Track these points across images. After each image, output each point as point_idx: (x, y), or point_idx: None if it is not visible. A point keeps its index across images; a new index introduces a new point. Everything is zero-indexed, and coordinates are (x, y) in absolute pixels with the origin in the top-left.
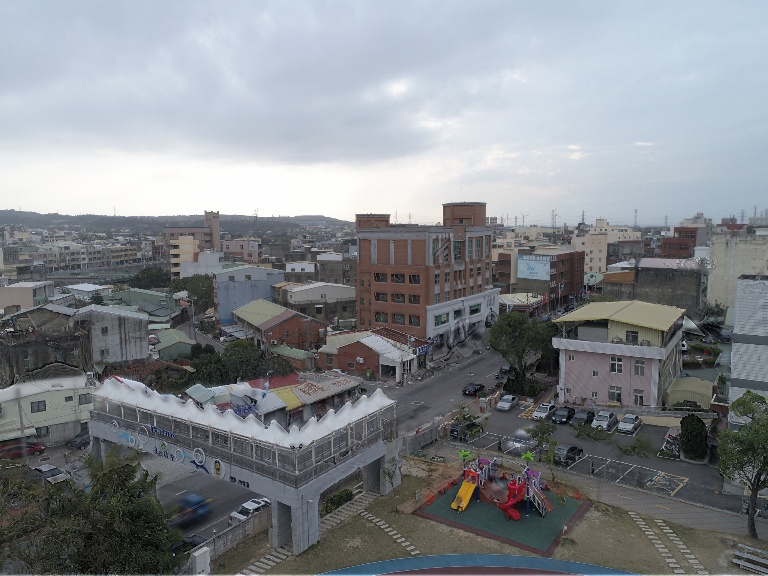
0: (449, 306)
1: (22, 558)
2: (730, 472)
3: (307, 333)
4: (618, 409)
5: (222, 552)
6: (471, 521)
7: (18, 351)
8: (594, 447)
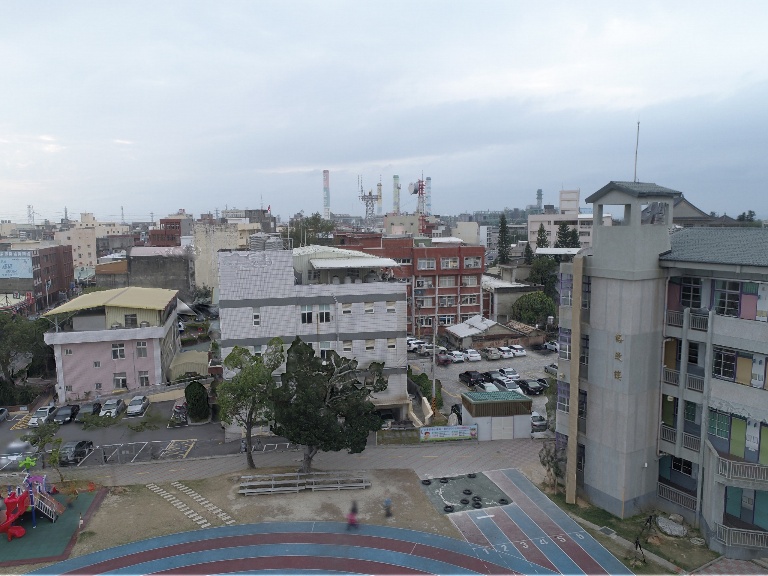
0: None
1: None
2: (229, 418)
3: None
4: (125, 394)
5: None
6: None
7: None
8: (104, 437)
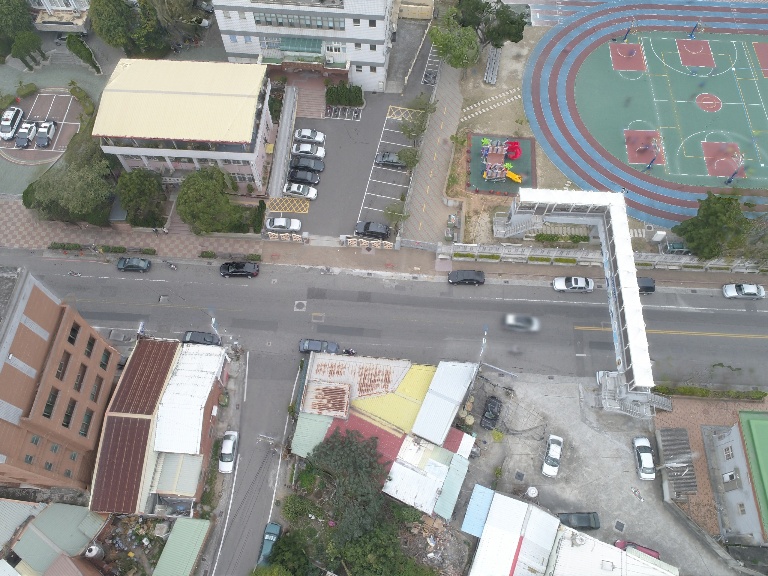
0: None
1: None
2: (464, 64)
3: None
4: None
5: None
6: (527, 172)
7: None
8: (360, 153)
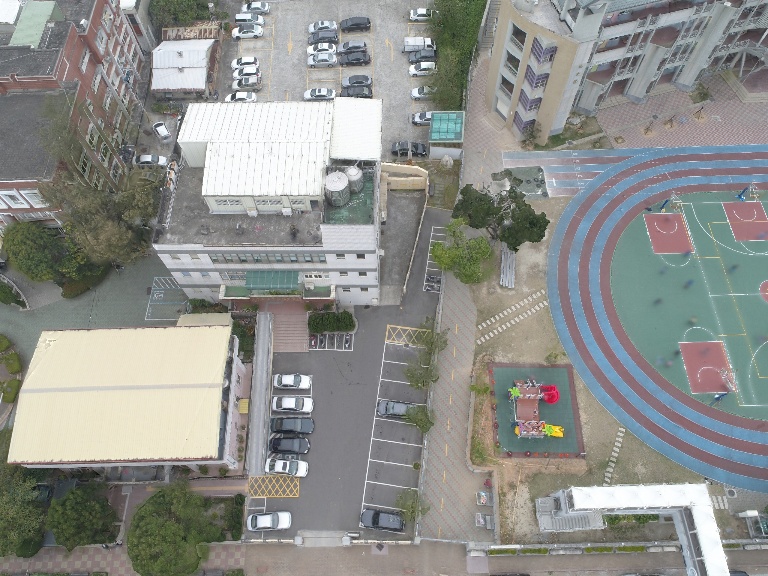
0: None
1: None
2: (477, 277)
3: None
4: None
5: None
6: (568, 418)
7: None
8: (357, 399)
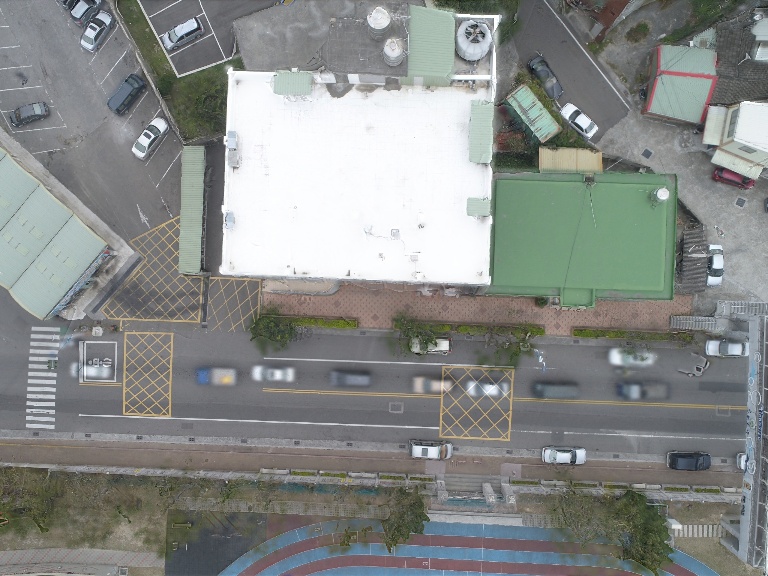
0: None
1: None
2: None
3: None
4: None
5: None
6: None
7: None
8: None
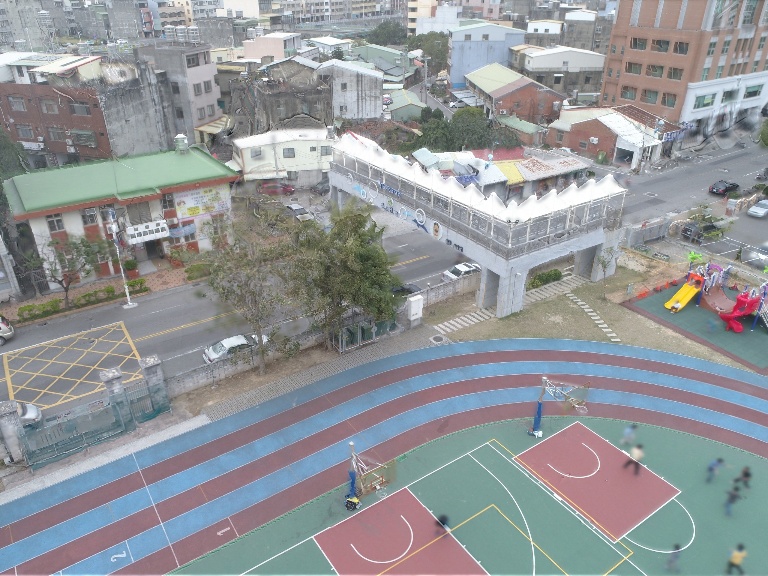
0: (719, 85)
1: (280, 275)
2: None
3: (540, 105)
4: None
5: (433, 302)
6: (683, 323)
7: (272, 100)
8: None
